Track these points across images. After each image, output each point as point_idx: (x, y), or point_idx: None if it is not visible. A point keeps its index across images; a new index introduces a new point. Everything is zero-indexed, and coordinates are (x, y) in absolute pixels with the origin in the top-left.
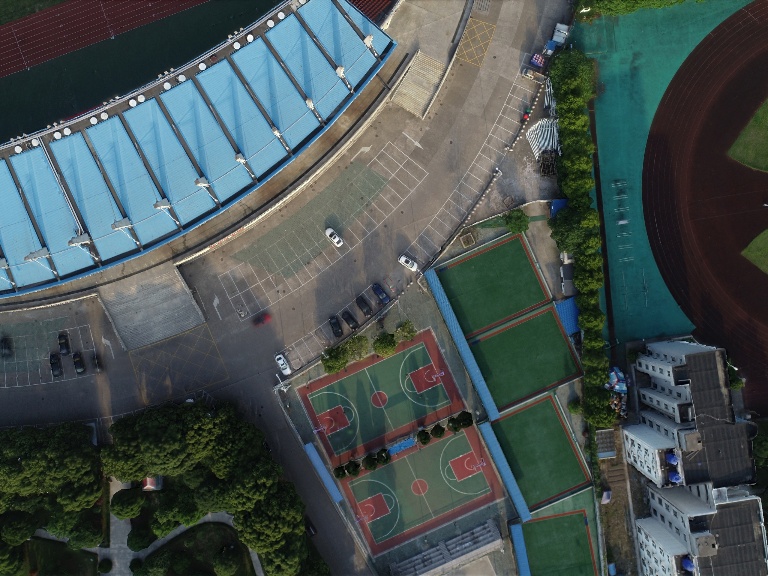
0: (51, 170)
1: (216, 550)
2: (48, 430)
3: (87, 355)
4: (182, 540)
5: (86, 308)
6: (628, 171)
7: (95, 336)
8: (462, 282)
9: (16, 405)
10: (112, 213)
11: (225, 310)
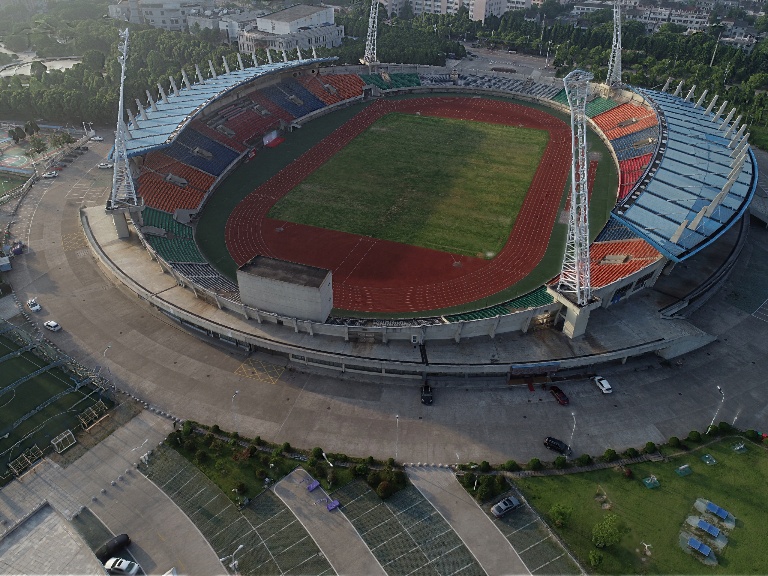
0: None
1: None
2: None
3: None
4: None
5: None
6: None
7: None
8: (8, 184)
9: None
10: None
11: None
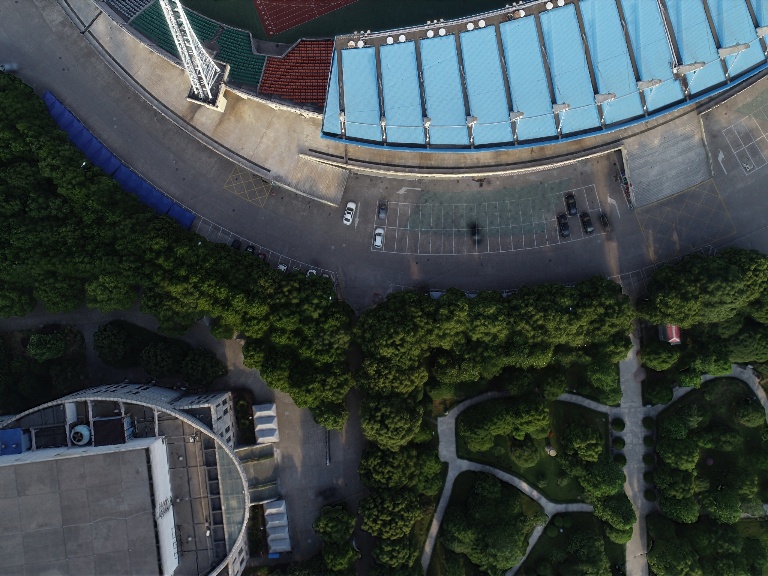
0: (655, 0)
1: (729, 404)
2: (585, 283)
3: (593, 215)
4: (694, 396)
5: (591, 168)
6: None
7: (601, 196)
8: None
9: (524, 268)
10: (707, 44)
11: (730, 164)
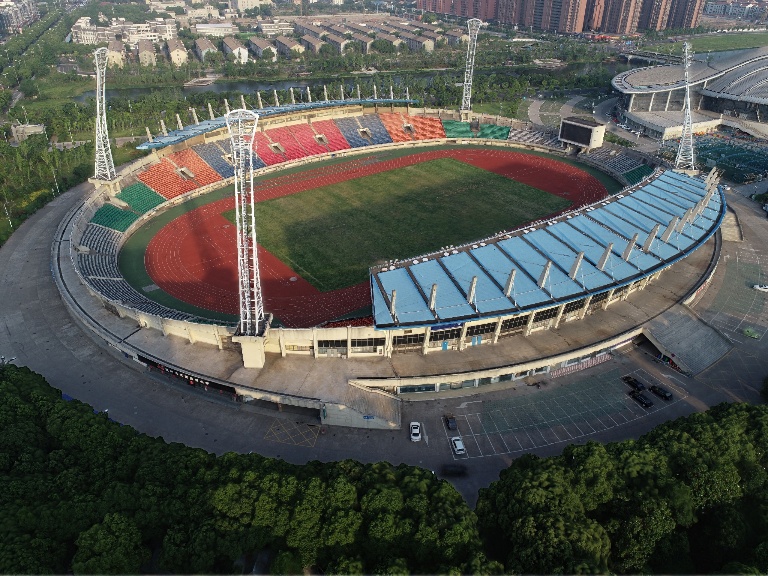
0: None
1: None
2: None
3: None
4: None
5: (628, 359)
6: None
7: (654, 374)
8: None
9: None
10: None
11: (739, 338)
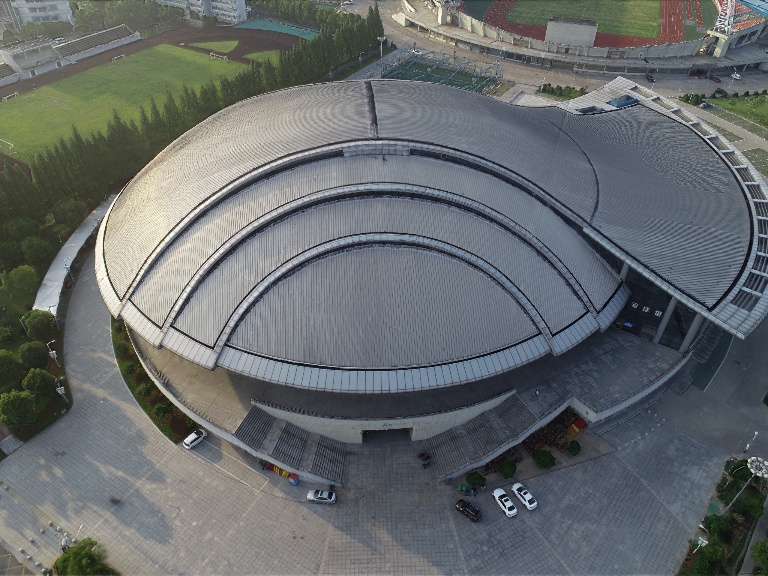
0: None
1: None
2: None
3: None
4: None
5: None
6: (308, 36)
7: None
8: None
9: None
10: None
11: None
